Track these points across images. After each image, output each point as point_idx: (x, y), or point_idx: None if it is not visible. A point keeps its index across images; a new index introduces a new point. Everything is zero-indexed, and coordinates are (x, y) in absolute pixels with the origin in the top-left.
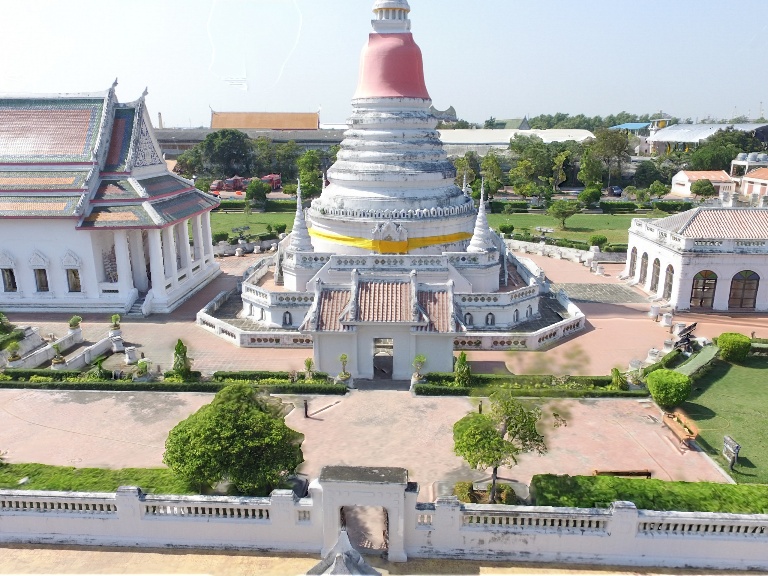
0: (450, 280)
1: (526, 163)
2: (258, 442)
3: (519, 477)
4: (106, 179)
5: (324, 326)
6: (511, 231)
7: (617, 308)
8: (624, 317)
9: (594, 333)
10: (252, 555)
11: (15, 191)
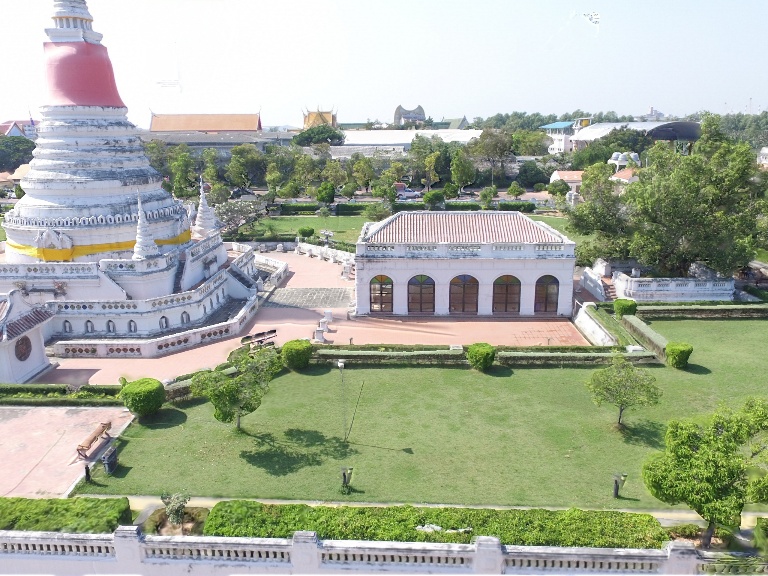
0: (11, 290)
1: (397, 164)
2: None
3: None
4: None
5: None
6: (311, 234)
7: (304, 313)
8: (295, 322)
9: (238, 339)
10: None
11: None
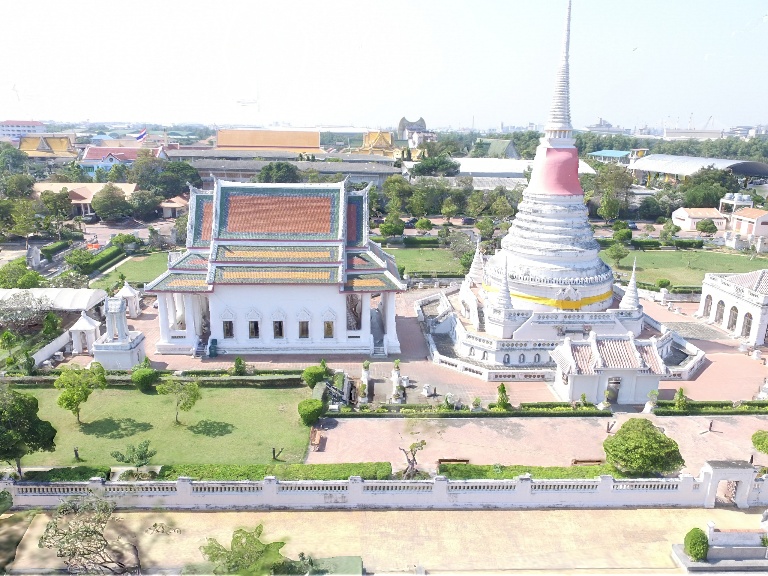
0: (654, 338)
1: None
2: (670, 450)
3: (764, 464)
4: (350, 252)
5: (582, 371)
6: None
7: (714, 344)
8: (724, 352)
9: (714, 365)
10: (670, 508)
11: (287, 263)
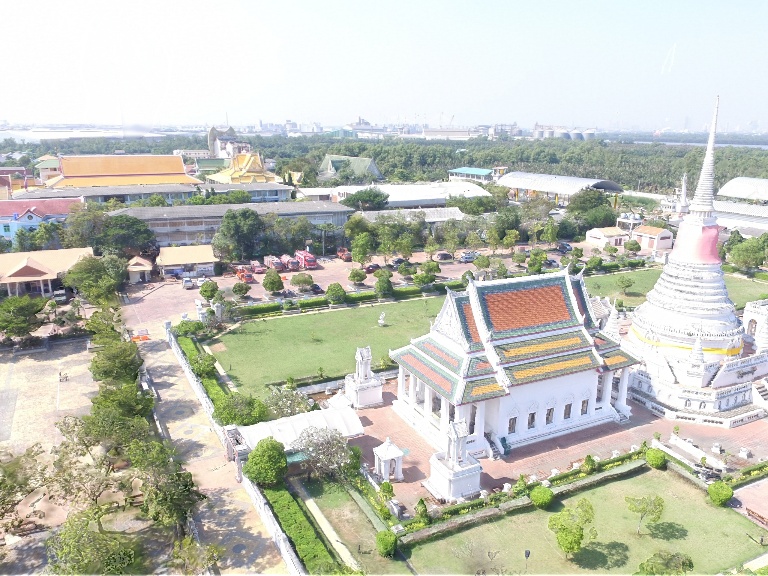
0: None
1: (516, 232)
2: None
3: None
4: None
5: None
6: (622, 305)
7: None
8: None
9: None
10: None
11: (555, 354)
